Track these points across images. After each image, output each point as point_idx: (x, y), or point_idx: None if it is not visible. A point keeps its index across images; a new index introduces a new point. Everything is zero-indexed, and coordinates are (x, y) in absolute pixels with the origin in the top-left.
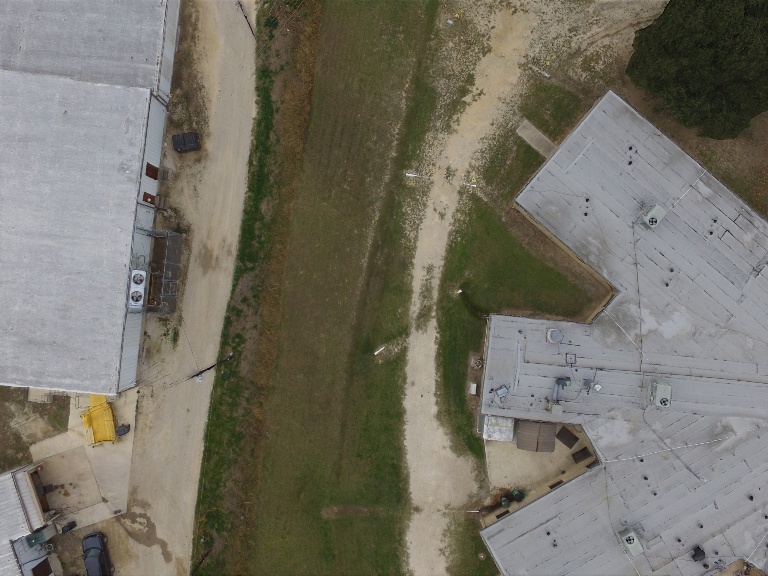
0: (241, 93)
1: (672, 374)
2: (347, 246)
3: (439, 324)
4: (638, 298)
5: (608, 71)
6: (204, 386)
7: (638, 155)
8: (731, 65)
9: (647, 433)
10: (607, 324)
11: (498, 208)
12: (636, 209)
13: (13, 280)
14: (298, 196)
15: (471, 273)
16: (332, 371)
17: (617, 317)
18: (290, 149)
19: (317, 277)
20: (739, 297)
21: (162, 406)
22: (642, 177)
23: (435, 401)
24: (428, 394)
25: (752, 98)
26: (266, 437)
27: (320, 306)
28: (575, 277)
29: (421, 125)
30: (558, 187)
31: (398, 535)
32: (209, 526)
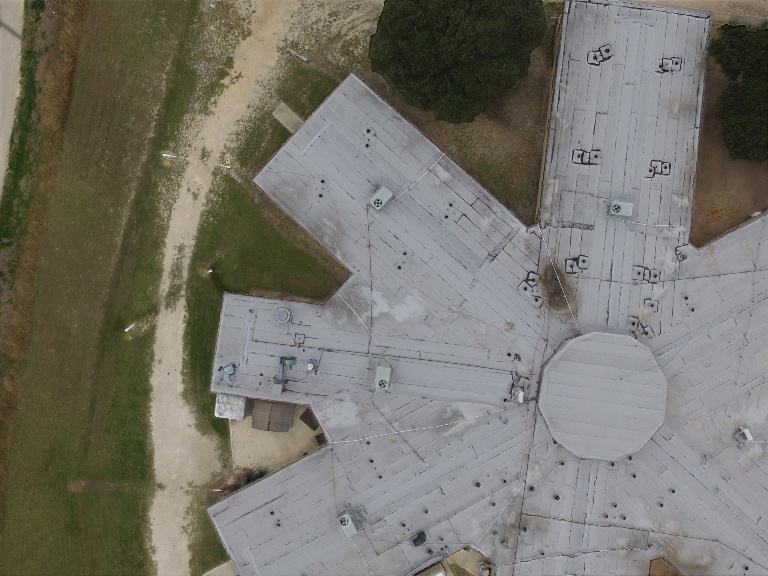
0: (6, 73)
1: (400, 357)
2: (102, 224)
3: (188, 303)
4: (370, 280)
5: (366, 56)
6: None
7: (377, 138)
8: (444, 47)
9: (375, 416)
10: (339, 305)
11: (252, 189)
12: (370, 191)
13: None
14: (56, 174)
15: (222, 253)
16: (83, 346)
17: (349, 299)
18: (49, 128)
19: (72, 254)
20: (471, 281)
21: None
22: (379, 160)
23: (182, 379)
24: (175, 372)
25: (474, 81)
26: (17, 409)
27: (74, 282)
28: (325, 259)
29: (180, 107)
30: (295, 168)
31: (141, 511)
32: None
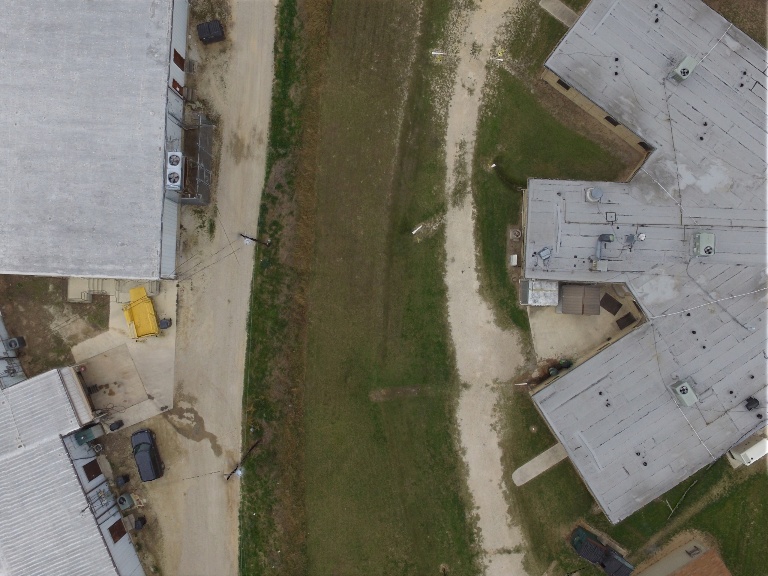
0: None
1: (713, 226)
2: (378, 127)
3: (475, 199)
4: (674, 153)
5: None
6: (244, 276)
7: (664, 13)
8: None
9: (692, 287)
10: (645, 181)
11: (526, 81)
12: (666, 65)
13: (48, 170)
14: (326, 80)
15: (503, 147)
16: (371, 253)
17: (654, 174)
18: (315, 33)
19: (350, 160)
20: None
21: (202, 298)
22: (669, 34)
23: (476, 276)
24: (469, 269)
25: None
26: (309, 323)
27: (355, 189)
28: (607, 144)
29: (444, 4)
30: (587, 48)
31: (448, 413)
32: (257, 416)
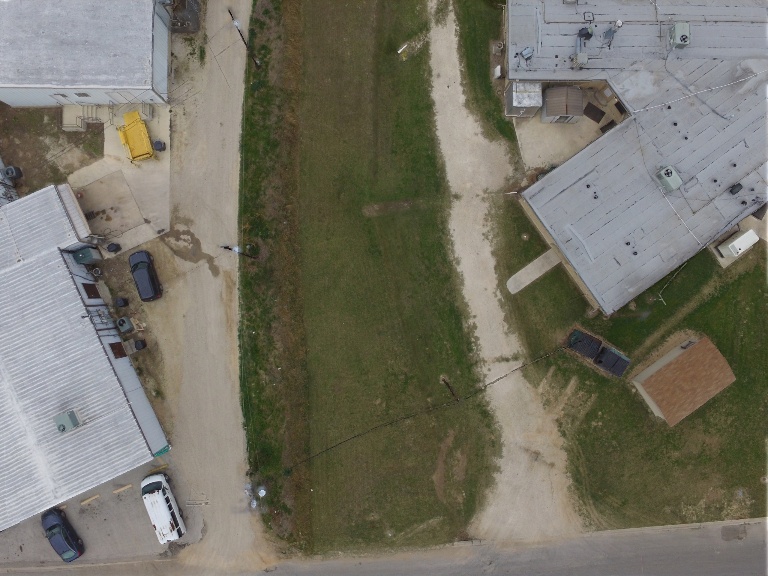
0: None
1: (688, 21)
2: None
3: (457, 17)
4: None
5: None
6: (235, 99)
7: None
8: None
9: (671, 82)
10: None
11: None
12: None
13: None
14: None
15: None
16: (358, 72)
17: None
18: None
19: None
20: None
21: (195, 123)
22: None
23: (462, 90)
24: (454, 84)
25: None
26: (301, 142)
27: (340, 12)
28: None
29: None
30: None
31: (440, 224)
32: (253, 235)
